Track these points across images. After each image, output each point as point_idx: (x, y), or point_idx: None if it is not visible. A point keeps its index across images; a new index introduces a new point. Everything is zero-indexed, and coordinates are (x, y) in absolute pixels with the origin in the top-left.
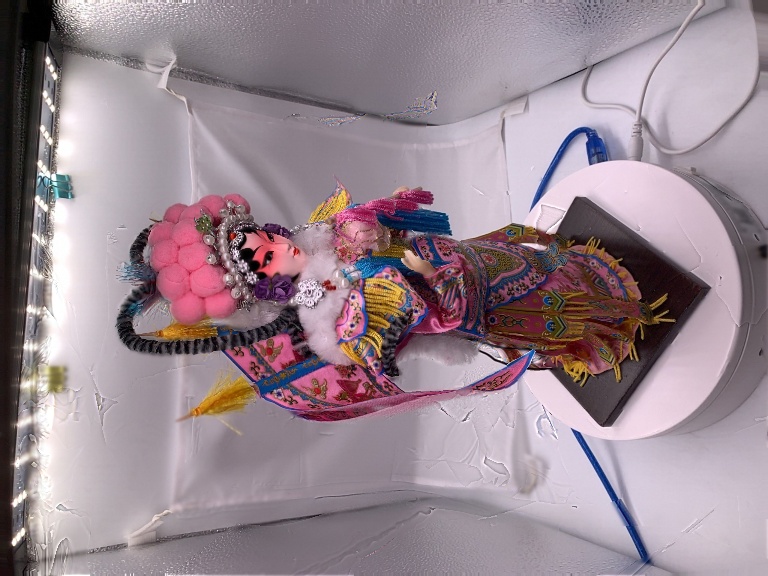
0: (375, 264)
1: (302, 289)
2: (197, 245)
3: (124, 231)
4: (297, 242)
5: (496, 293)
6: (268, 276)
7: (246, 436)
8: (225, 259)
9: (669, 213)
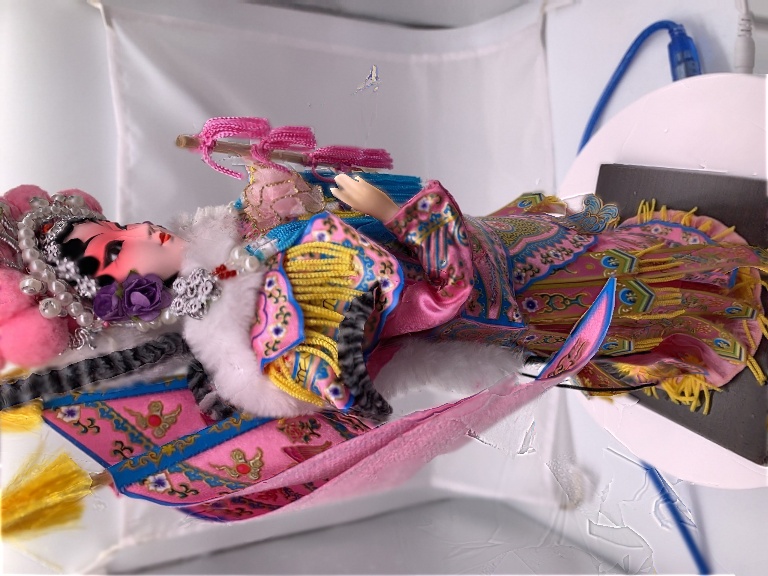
0: (298, 224)
1: (180, 289)
2: None
3: None
4: None
5: (523, 263)
6: (118, 281)
7: (73, 574)
8: (28, 258)
9: (740, 123)
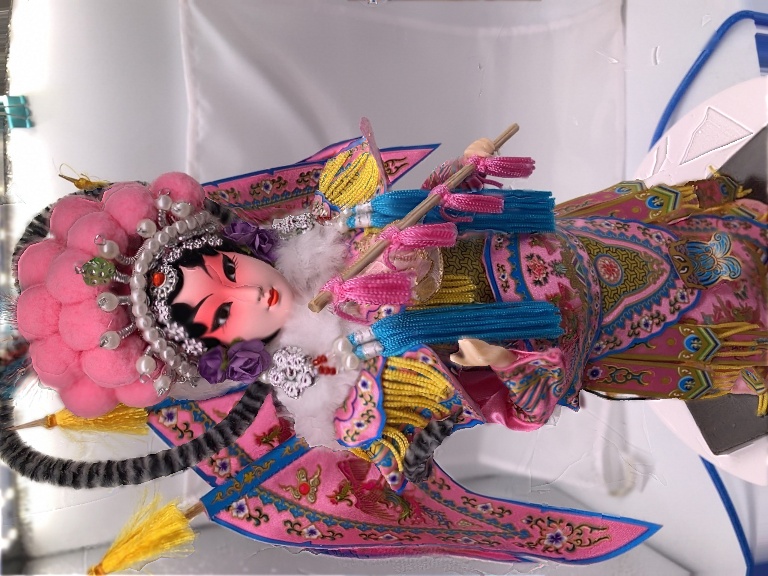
0: (407, 335)
1: (280, 365)
2: (87, 310)
3: (7, 213)
4: (283, 262)
5: (610, 335)
6: (223, 341)
7: None
8: (141, 327)
9: None
